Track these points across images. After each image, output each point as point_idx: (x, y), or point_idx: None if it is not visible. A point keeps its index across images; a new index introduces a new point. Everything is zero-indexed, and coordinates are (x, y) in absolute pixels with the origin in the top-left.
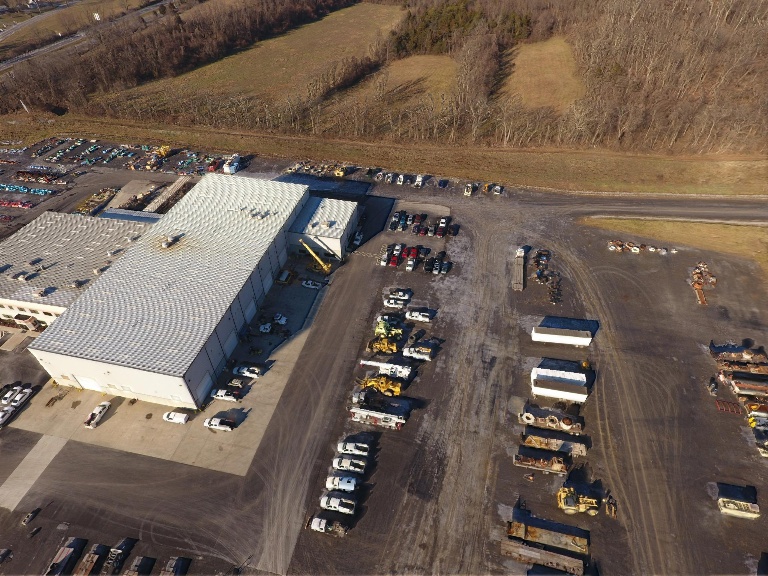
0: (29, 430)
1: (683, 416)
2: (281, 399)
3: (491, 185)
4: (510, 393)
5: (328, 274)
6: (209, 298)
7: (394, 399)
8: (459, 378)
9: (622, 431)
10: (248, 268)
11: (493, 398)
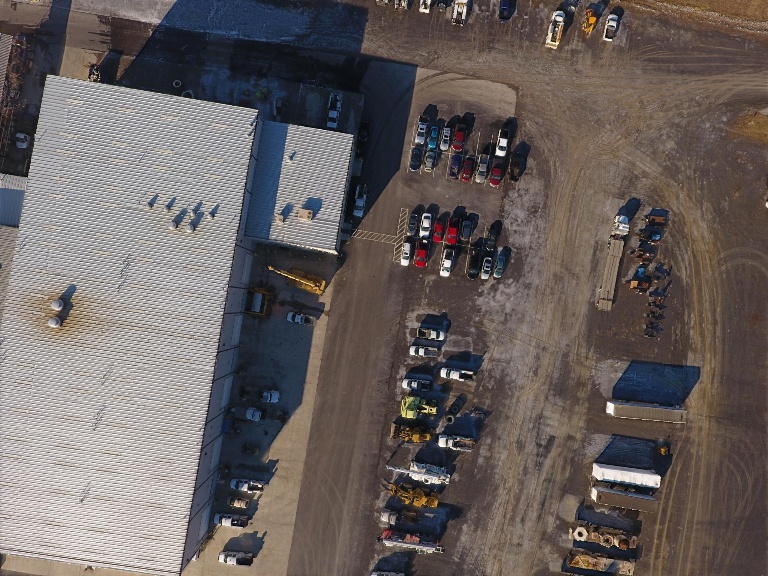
0: (28, 573)
1: (754, 516)
2: (297, 517)
3: (600, 4)
4: (564, 491)
5: (322, 292)
6: (167, 438)
7: (429, 508)
8: (506, 472)
9: (679, 538)
10: (205, 367)
11: (543, 499)
